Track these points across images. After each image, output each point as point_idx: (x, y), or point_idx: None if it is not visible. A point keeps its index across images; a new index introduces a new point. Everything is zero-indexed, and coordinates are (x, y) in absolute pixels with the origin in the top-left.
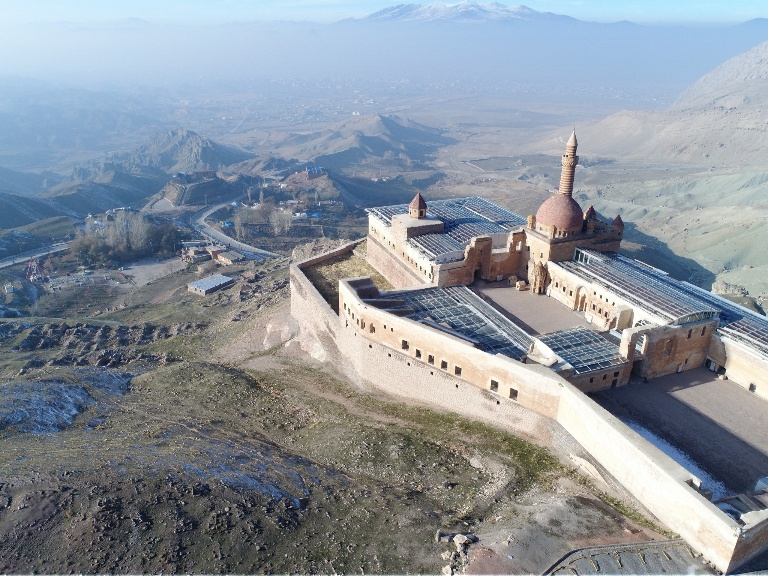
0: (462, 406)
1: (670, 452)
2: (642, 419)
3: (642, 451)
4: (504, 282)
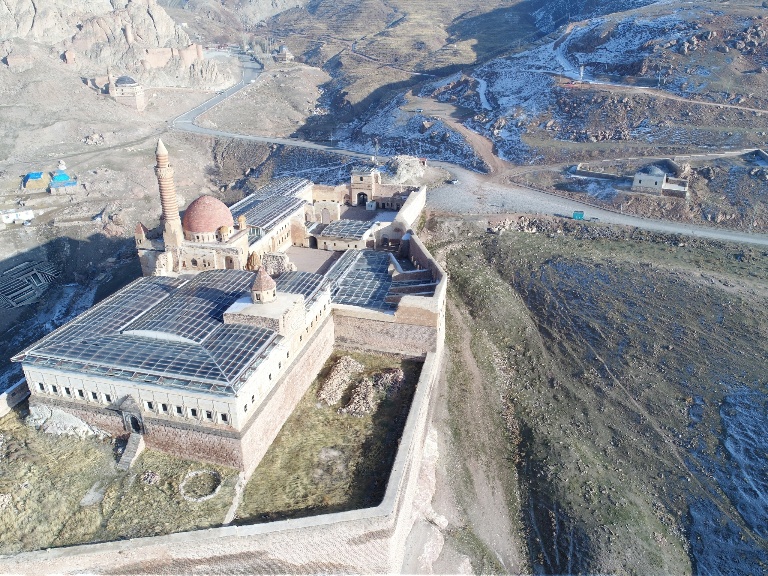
0: None
1: None
2: None
3: None
4: None
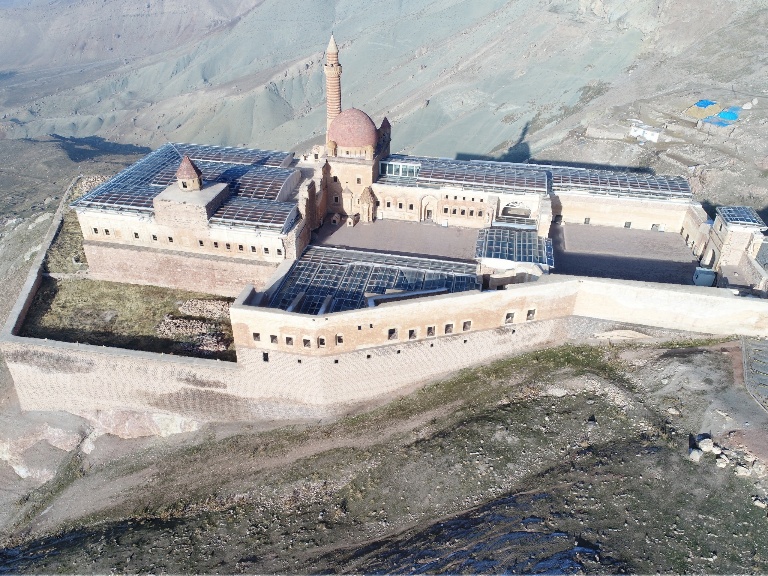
0: (471, 357)
1: None
2: None
3: (694, 293)
4: (326, 225)
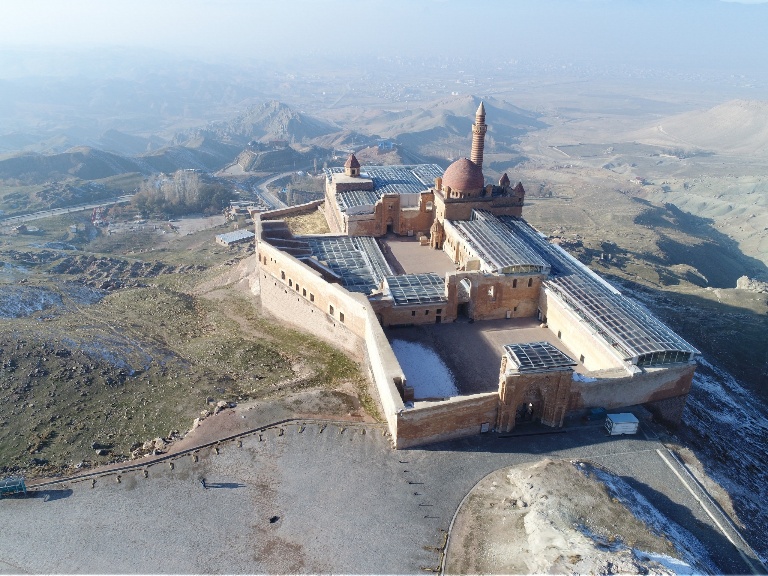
0: (316, 328)
1: (440, 371)
2: (440, 347)
3: (380, 356)
4: (414, 237)
